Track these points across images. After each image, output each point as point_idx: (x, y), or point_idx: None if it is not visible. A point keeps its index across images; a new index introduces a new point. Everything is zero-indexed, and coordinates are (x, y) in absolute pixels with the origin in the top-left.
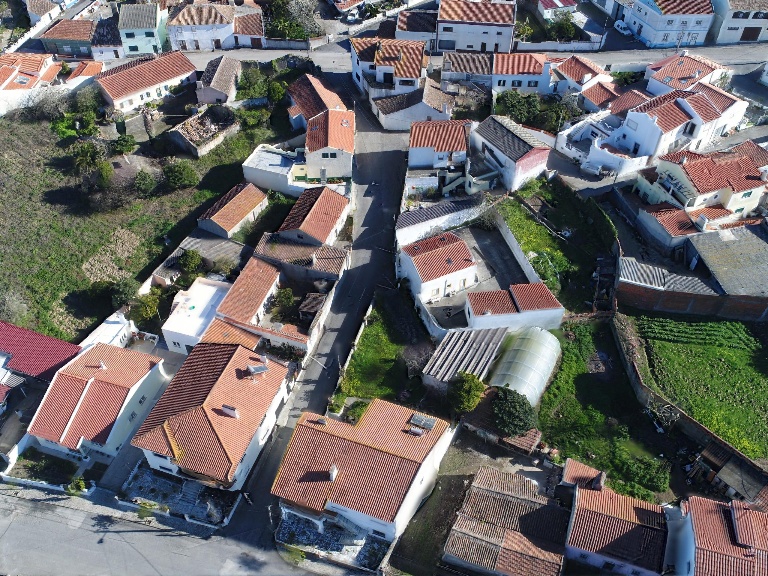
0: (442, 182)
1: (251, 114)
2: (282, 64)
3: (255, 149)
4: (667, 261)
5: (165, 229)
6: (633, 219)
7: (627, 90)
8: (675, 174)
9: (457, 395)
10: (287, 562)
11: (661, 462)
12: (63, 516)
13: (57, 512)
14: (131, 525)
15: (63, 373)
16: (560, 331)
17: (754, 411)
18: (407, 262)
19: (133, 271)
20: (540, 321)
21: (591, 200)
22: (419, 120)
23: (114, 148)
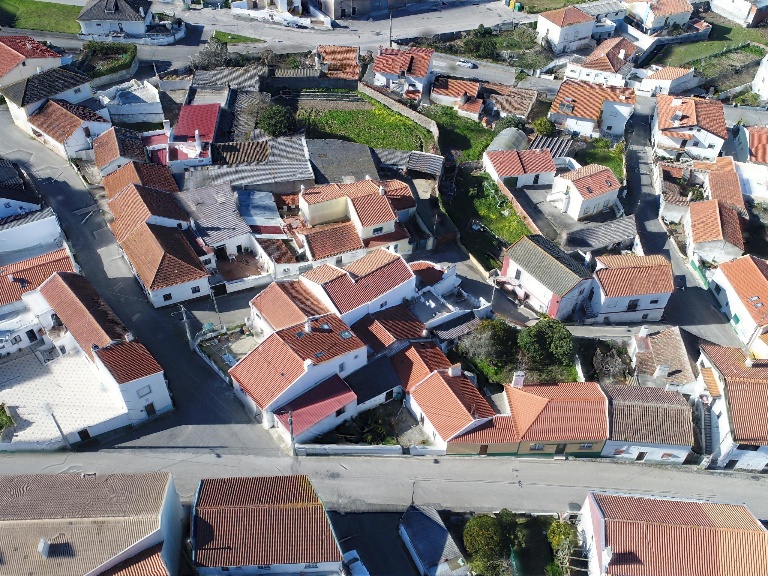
0: None
1: None
2: None
3: None
4: None
5: None
6: None
7: (392, 372)
8: None
9: None
10: None
11: None
12: None
13: None
14: None
15: None
16: None
17: None
18: None
19: None
20: None
21: None
22: None
23: None
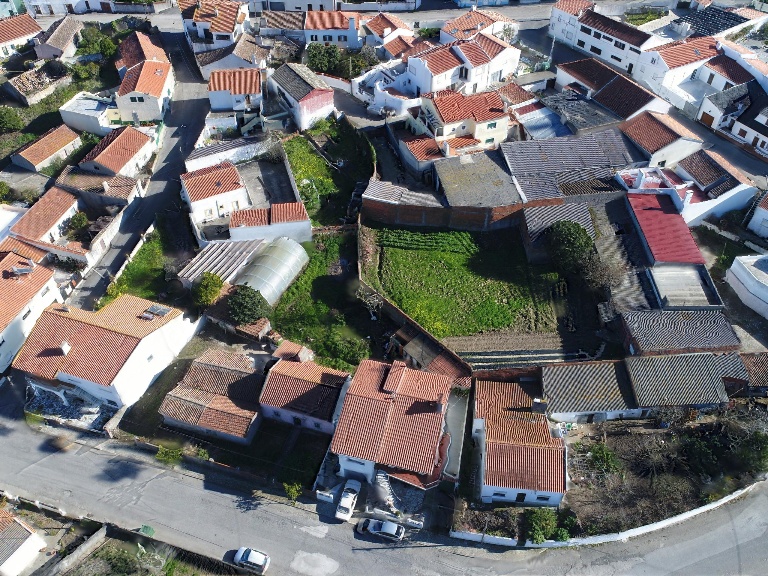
0: (241, 123)
1: (86, 68)
2: (122, 25)
3: (74, 96)
4: (419, 184)
5: None
6: (397, 150)
7: None
8: (431, 108)
9: (197, 290)
10: (32, 428)
11: (361, 340)
12: None
13: None
14: None
15: None
16: (313, 243)
17: (455, 301)
18: (183, 186)
19: None
20: (292, 233)
21: (363, 134)
22: None
23: None
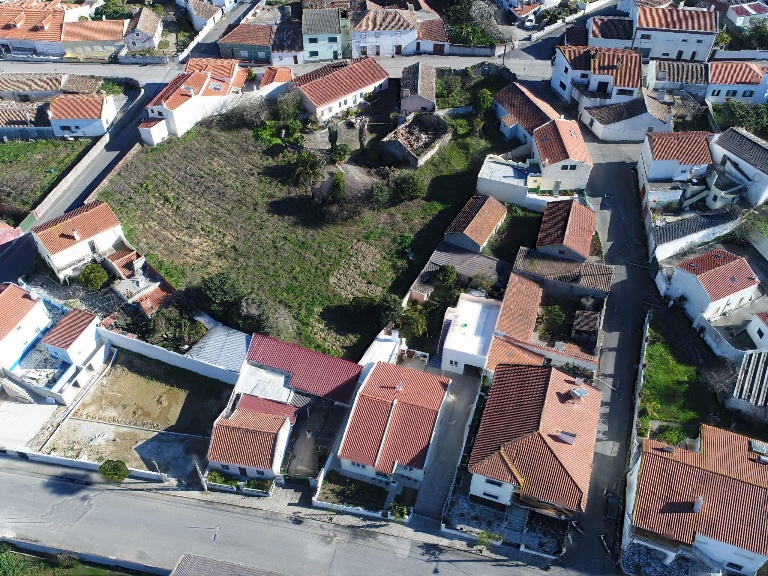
0: (682, 195)
1: (457, 123)
2: (476, 71)
3: (485, 160)
4: None
5: (405, 242)
6: None
7: None
8: None
9: None
10: None
11: None
12: (387, 544)
13: (380, 539)
14: (462, 554)
15: (364, 394)
16: None
17: None
18: (686, 280)
19: (382, 286)
20: None
21: None
22: (639, 131)
23: (332, 158)
